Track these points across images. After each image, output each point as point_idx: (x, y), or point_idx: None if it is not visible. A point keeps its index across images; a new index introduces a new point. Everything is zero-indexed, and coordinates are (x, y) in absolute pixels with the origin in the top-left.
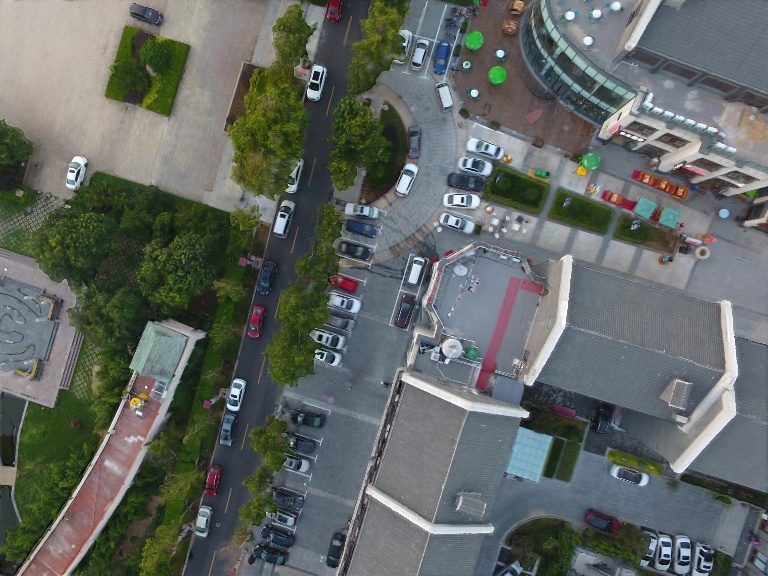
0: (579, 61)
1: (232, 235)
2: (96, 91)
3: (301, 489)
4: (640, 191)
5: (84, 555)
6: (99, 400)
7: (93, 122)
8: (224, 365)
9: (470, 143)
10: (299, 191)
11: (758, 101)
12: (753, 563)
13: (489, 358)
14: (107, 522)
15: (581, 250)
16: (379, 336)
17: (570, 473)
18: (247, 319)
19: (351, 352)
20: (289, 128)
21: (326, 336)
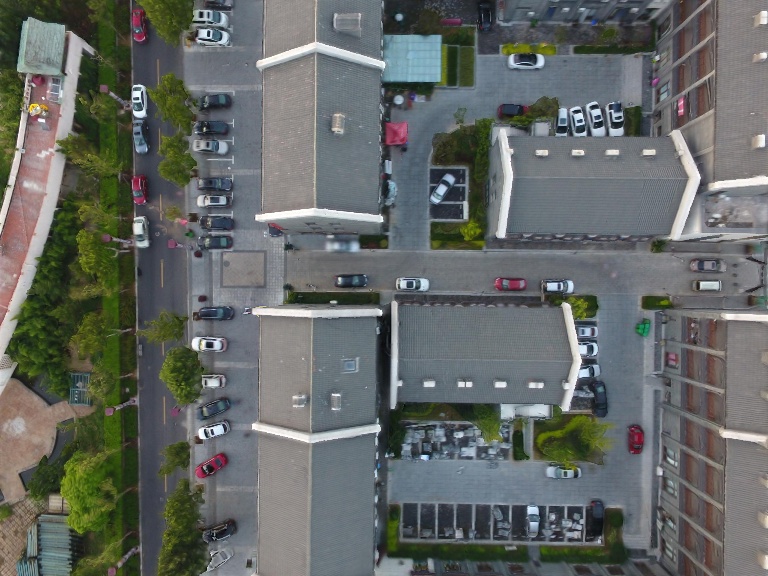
0: None
1: None
2: None
3: (227, 174)
4: None
5: (30, 288)
6: (3, 131)
7: None
8: (120, 78)
9: None
10: None
11: None
12: (659, 102)
13: None
14: (44, 249)
15: None
16: (259, 6)
17: (471, 76)
18: (130, 28)
19: (237, 30)
20: None
21: (206, 11)
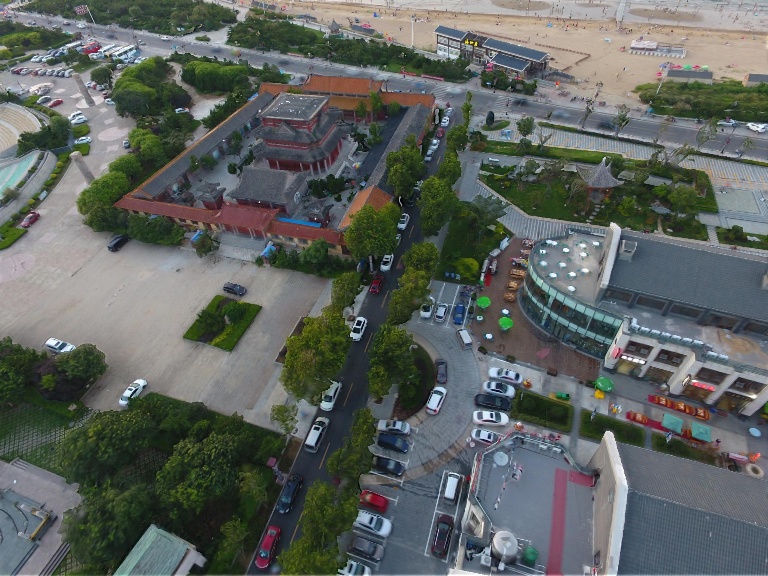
0: (569, 302)
1: (264, 442)
2: (177, 335)
3: None
4: (662, 413)
5: None
6: None
7: (165, 355)
8: None
9: (491, 371)
10: (334, 410)
11: (725, 323)
12: None
13: (552, 567)
14: None
15: None
16: (413, 570)
17: None
18: (258, 544)
19: None
20: (338, 338)
21: (350, 563)
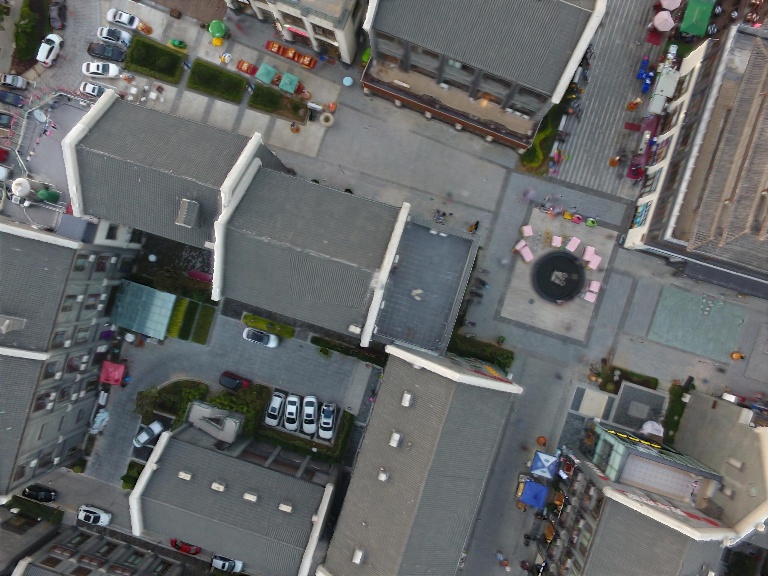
0: None
1: None
2: None
3: None
4: (273, 61)
5: None
6: None
7: None
8: None
9: (110, 14)
10: None
11: None
12: None
13: None
14: None
15: (218, 119)
16: None
17: (204, 335)
18: None
19: None
20: None
21: None
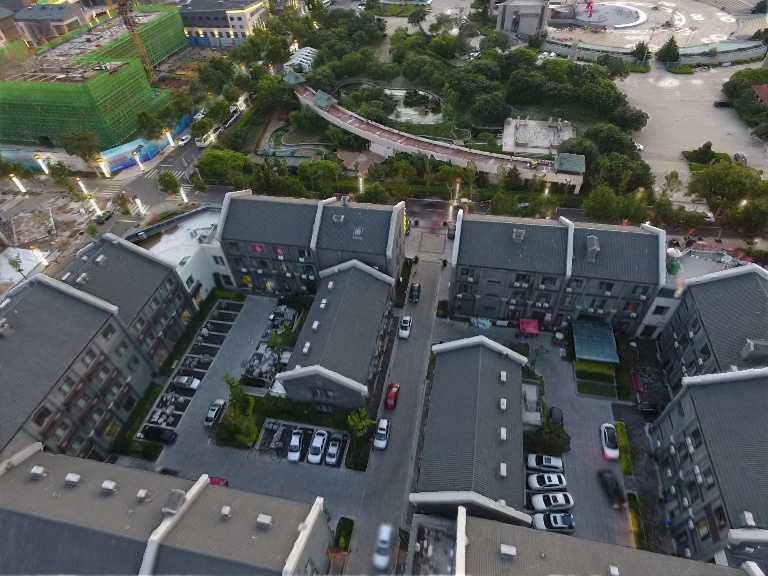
0: None
1: None
2: (682, 150)
3: None
4: None
5: None
6: None
7: (664, 150)
8: (561, 203)
9: None
10: None
11: None
12: None
13: None
14: None
15: None
16: None
17: (588, 391)
18: None
19: None
20: (747, 181)
21: None
